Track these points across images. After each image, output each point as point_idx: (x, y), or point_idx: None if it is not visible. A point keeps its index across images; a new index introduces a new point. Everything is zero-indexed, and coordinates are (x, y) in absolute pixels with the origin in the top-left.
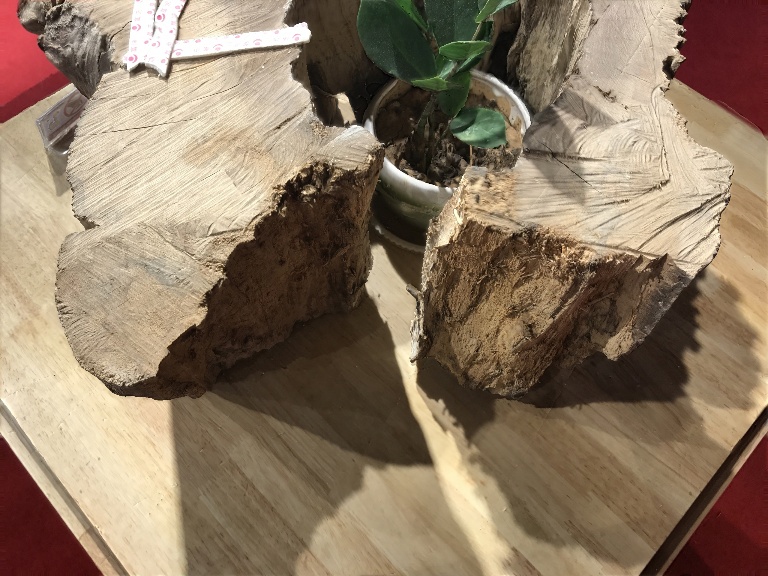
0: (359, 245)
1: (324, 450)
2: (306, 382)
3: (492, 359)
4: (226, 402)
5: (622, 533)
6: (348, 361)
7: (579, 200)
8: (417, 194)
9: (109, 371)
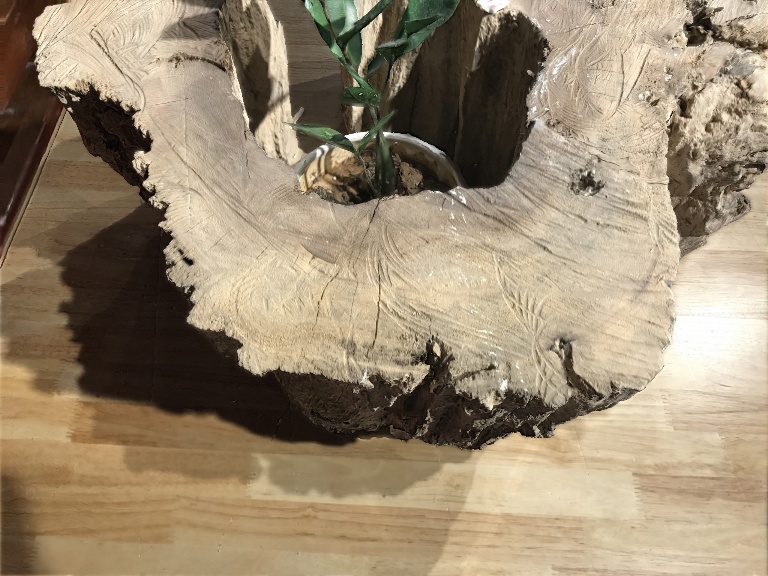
0: None
1: (294, 80)
2: None
3: None
4: None
5: (74, 154)
6: (327, 125)
7: None
8: None
9: None
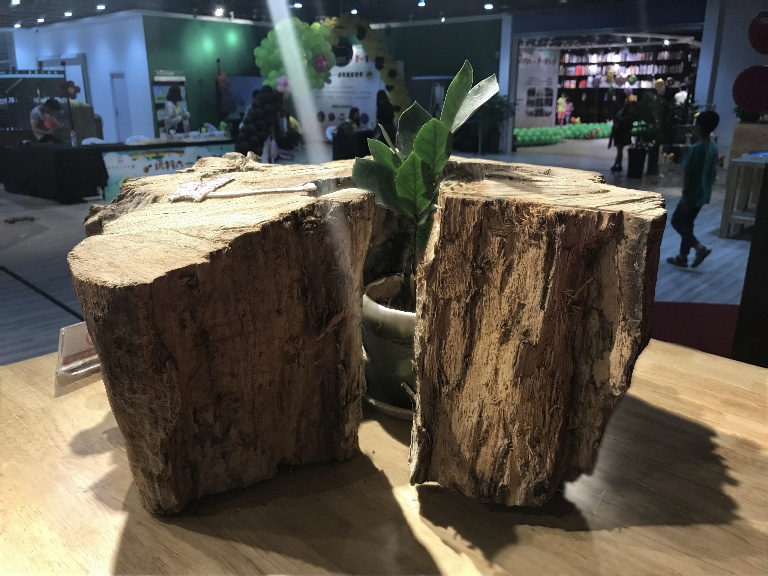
0: (353, 316)
1: (306, 573)
2: (288, 516)
3: (497, 418)
4: (189, 532)
5: None
6: (339, 499)
7: None
8: (407, 324)
9: (104, 280)
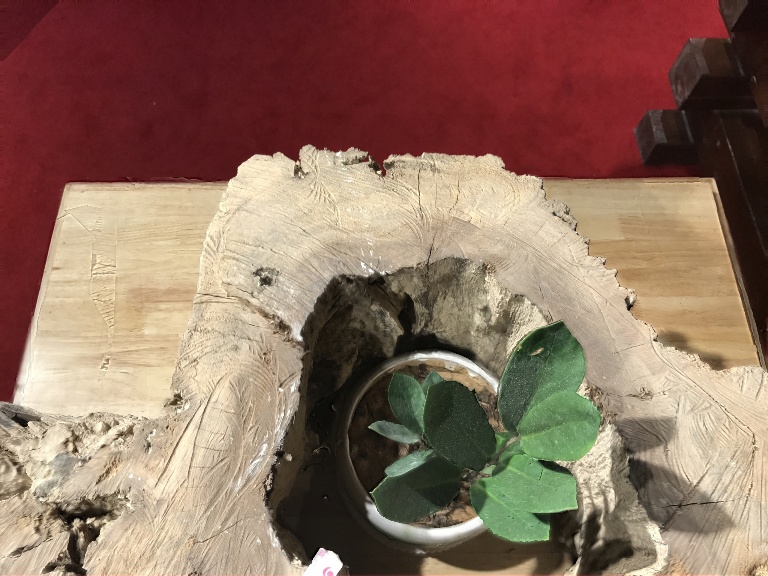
0: None
1: None
2: None
3: None
4: None
5: None
6: None
7: (729, 525)
8: (473, 532)
9: None
